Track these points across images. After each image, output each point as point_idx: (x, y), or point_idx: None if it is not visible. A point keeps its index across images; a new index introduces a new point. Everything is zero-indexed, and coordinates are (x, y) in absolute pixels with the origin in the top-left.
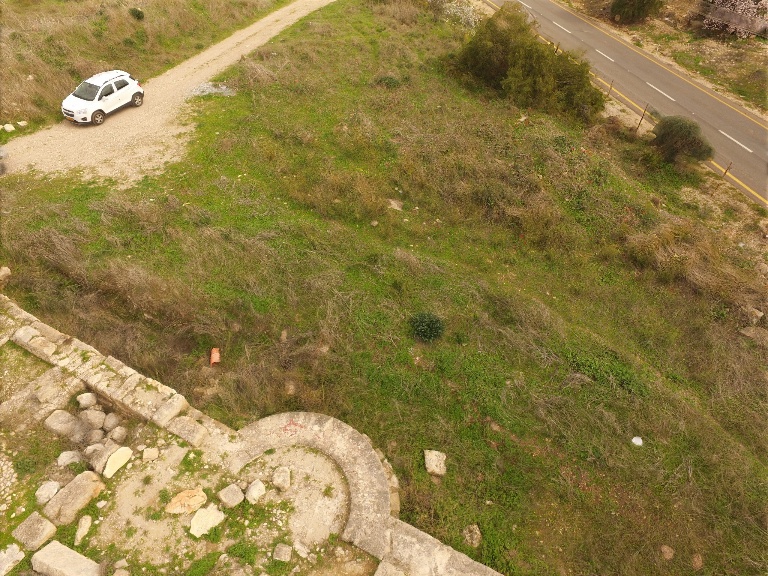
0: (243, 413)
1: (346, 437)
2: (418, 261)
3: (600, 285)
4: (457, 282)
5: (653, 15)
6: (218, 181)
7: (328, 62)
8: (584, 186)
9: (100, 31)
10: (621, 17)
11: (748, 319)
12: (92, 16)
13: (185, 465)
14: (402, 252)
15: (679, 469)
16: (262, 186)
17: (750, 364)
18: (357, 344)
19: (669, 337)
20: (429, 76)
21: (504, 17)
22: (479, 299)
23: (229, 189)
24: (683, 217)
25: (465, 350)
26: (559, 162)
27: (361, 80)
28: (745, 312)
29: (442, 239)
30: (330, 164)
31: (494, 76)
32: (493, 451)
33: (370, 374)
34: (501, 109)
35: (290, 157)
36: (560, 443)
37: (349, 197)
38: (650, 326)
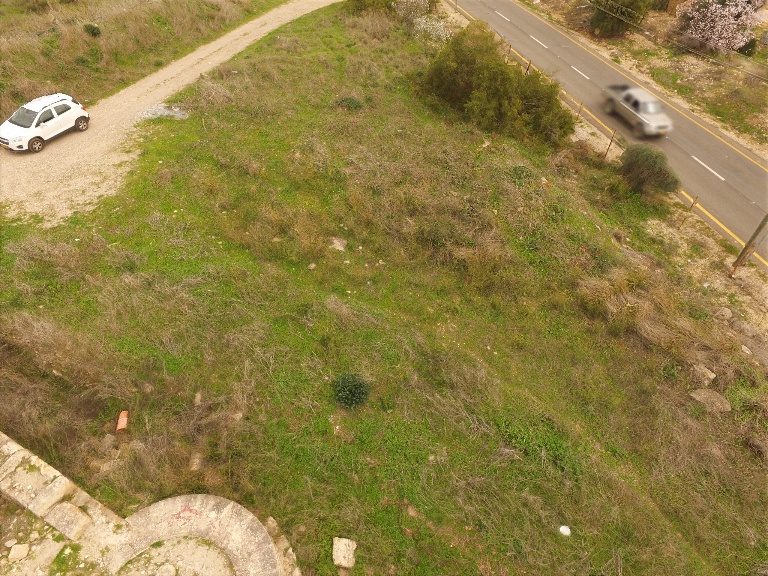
0: (139, 493)
1: (244, 526)
2: (350, 312)
3: (546, 338)
4: (392, 335)
5: (633, 29)
6: (151, 218)
7: (290, 81)
8: (539, 223)
9: (50, 50)
10: (600, 31)
11: (700, 380)
12: (44, 33)
13: (58, 564)
14: (336, 300)
15: (608, 566)
16: (197, 223)
17: (698, 434)
18: (274, 410)
19: (612, 403)
20: (394, 96)
21: (469, 37)
22: (412, 356)
23: (161, 227)
24: (646, 254)
25: (389, 418)
26: (515, 196)
27: (322, 101)
28: (697, 372)
29: (383, 284)
30: (273, 198)
31: (460, 97)
32: (408, 540)
33: (284, 445)
34: (464, 134)
35: (233, 189)
36: (480, 533)
37: (289, 236)
38: (594, 388)
